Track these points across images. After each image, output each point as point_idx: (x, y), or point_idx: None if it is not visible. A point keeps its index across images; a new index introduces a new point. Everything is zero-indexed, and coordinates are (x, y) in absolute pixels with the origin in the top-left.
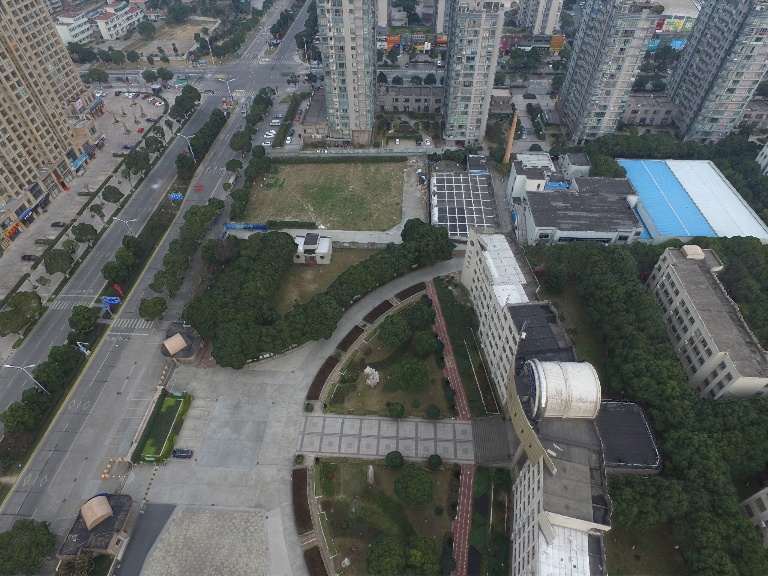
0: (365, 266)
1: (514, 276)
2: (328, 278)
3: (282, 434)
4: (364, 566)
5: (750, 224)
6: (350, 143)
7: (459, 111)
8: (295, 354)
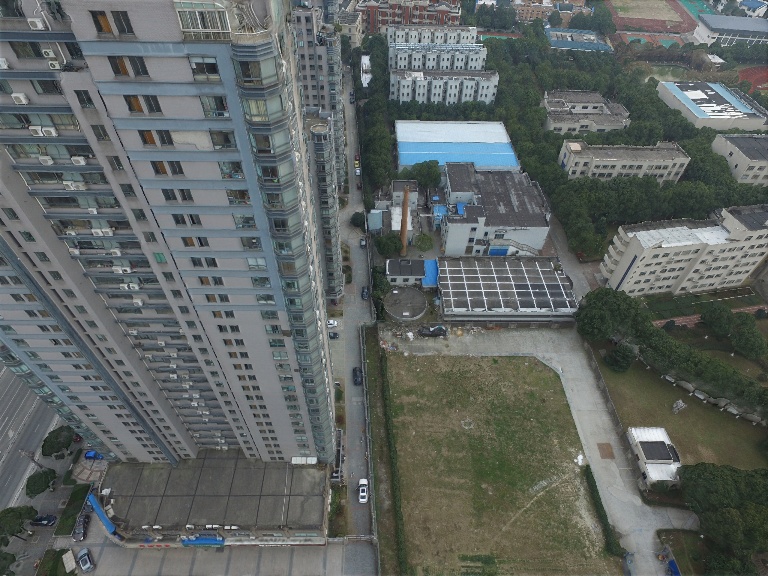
0: (708, 361)
1: (683, 232)
2: (680, 434)
3: None
4: None
5: (485, 127)
6: None
7: (338, 255)
8: None
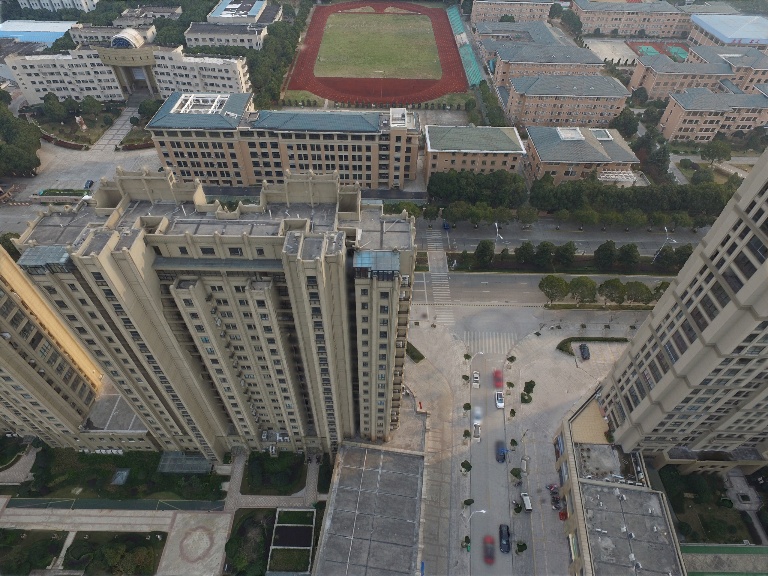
0: None
1: (54, 56)
2: None
3: (98, 156)
4: None
5: (68, 24)
6: None
7: None
8: (42, 156)
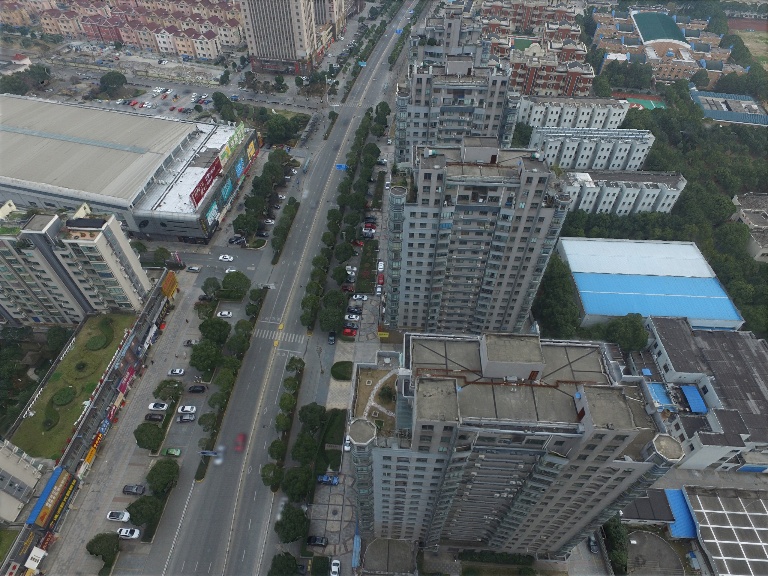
0: None
1: None
2: None
3: None
4: None
5: (674, 250)
6: None
7: None
8: None
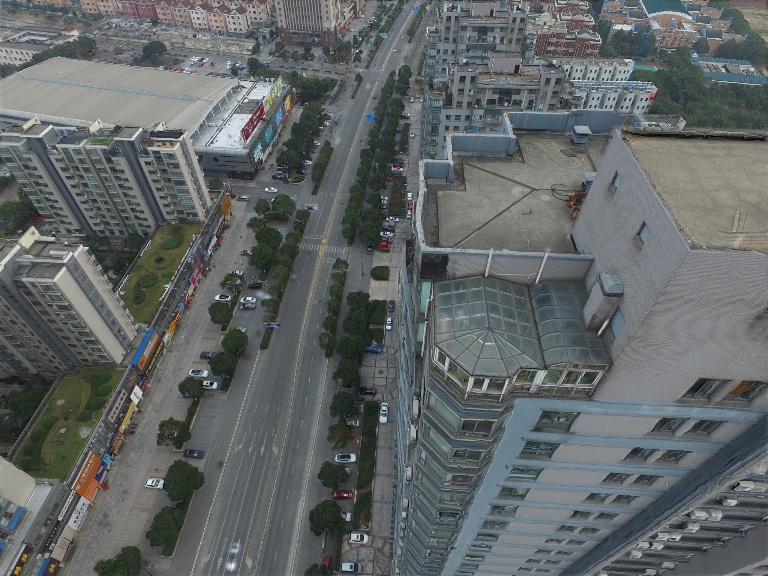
0: None
1: None
2: None
3: None
4: None
5: None
6: None
7: None
8: None
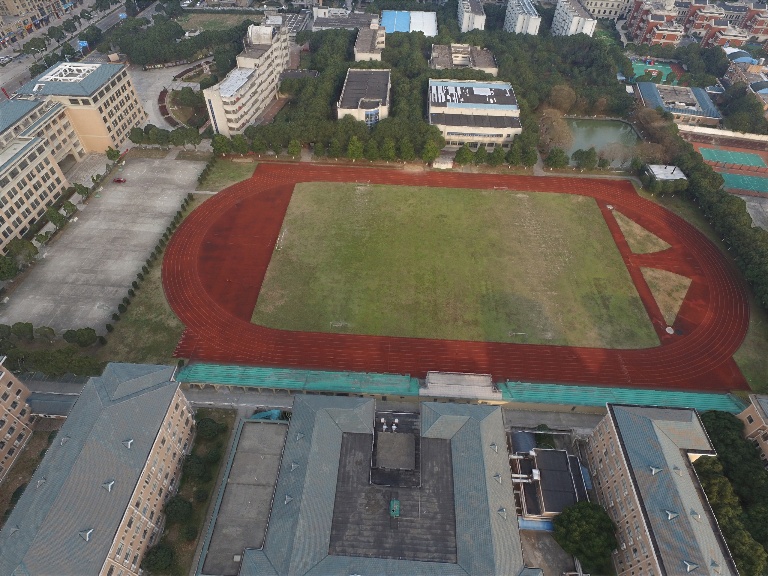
0: (213, 32)
1: None
2: None
3: (160, 85)
4: (183, 110)
5: (431, 32)
6: (235, 5)
7: None
8: (174, 68)
